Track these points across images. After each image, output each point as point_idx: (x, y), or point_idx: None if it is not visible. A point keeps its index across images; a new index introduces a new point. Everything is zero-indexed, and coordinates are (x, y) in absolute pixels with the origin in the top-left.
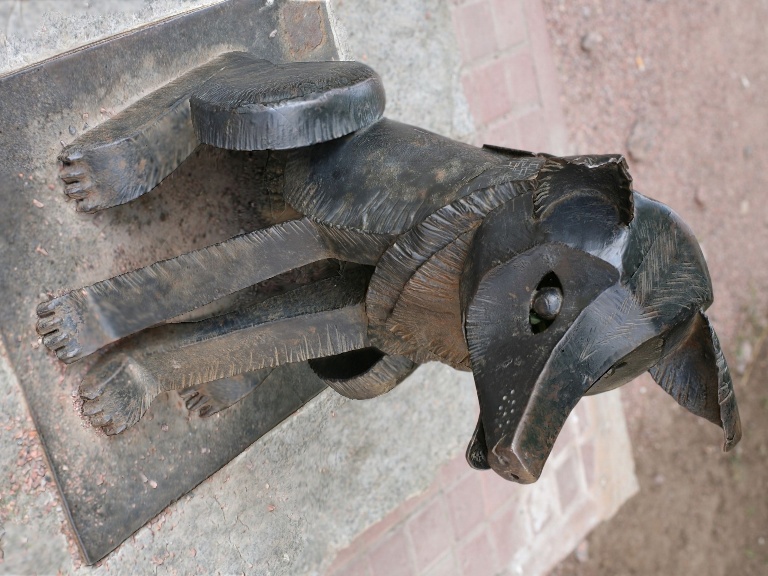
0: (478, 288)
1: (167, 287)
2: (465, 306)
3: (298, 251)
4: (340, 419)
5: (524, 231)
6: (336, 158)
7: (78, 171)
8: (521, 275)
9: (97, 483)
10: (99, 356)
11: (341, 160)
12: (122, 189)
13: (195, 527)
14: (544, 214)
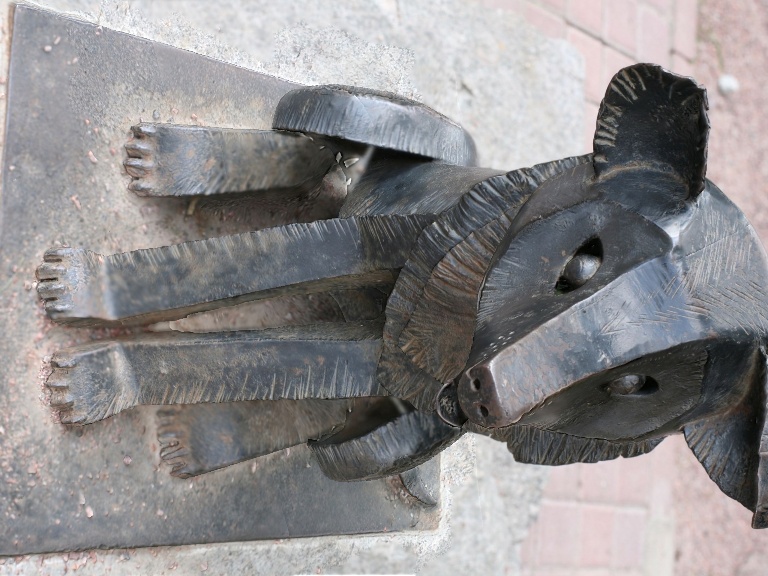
0: (509, 247)
1: (186, 271)
2: (489, 269)
3: (333, 257)
4: None
5: (577, 190)
6: (405, 175)
7: (145, 145)
8: (561, 237)
9: (28, 470)
10: (89, 339)
11: (409, 175)
12: (181, 179)
13: None
14: (605, 177)
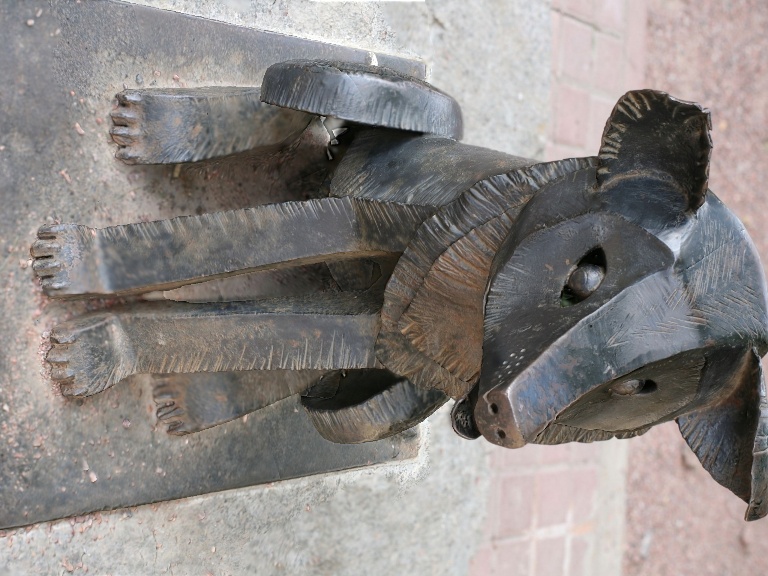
0: (513, 253)
1: (180, 246)
2: (493, 274)
3: (328, 235)
4: (314, 517)
5: (580, 199)
6: (397, 151)
7: (131, 114)
8: (564, 246)
9: (34, 443)
10: (85, 311)
11: (401, 152)
12: (168, 147)
13: (121, 551)
14: (606, 186)
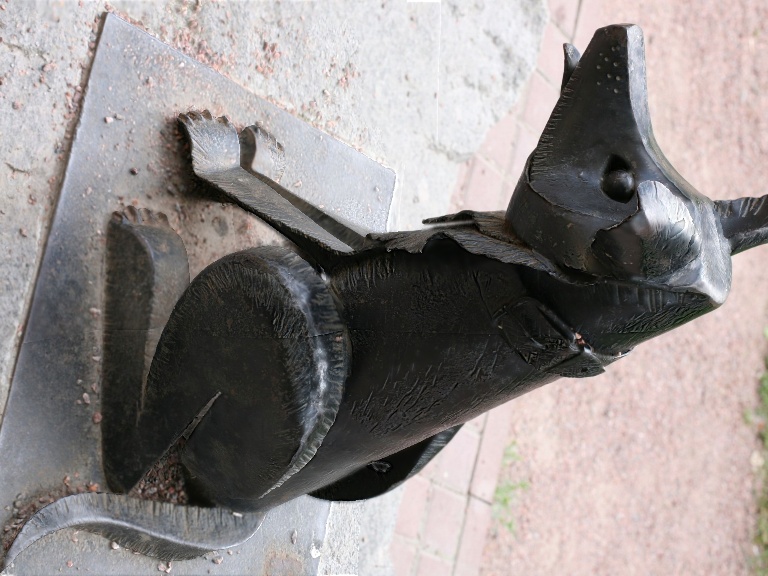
0: None
1: None
2: None
3: None
4: None
5: None
6: None
7: None
8: None
9: (151, 77)
10: None
11: None
12: None
13: (33, 127)
14: None
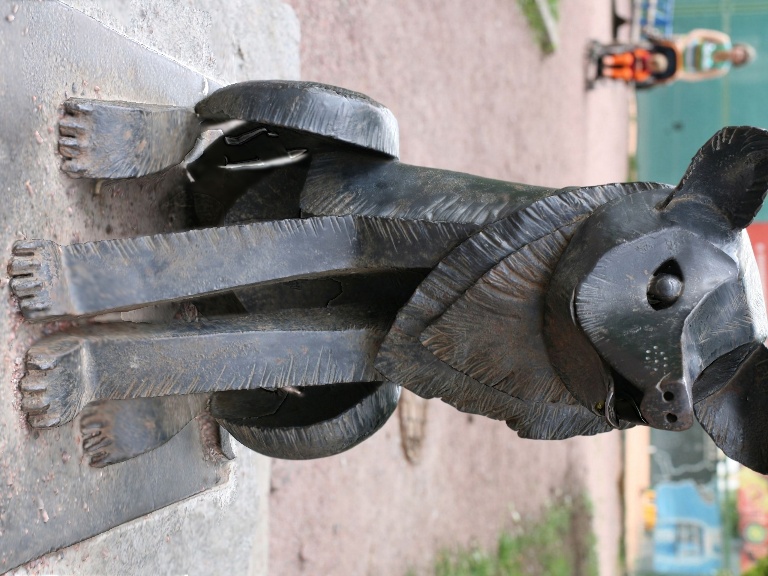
0: (596, 265)
1: (163, 264)
2: (576, 284)
3: (326, 252)
4: (171, 548)
5: (648, 218)
6: (378, 173)
7: (81, 124)
8: (641, 258)
9: (8, 481)
10: (42, 335)
11: (386, 175)
12: (117, 161)
13: None
14: (667, 207)
